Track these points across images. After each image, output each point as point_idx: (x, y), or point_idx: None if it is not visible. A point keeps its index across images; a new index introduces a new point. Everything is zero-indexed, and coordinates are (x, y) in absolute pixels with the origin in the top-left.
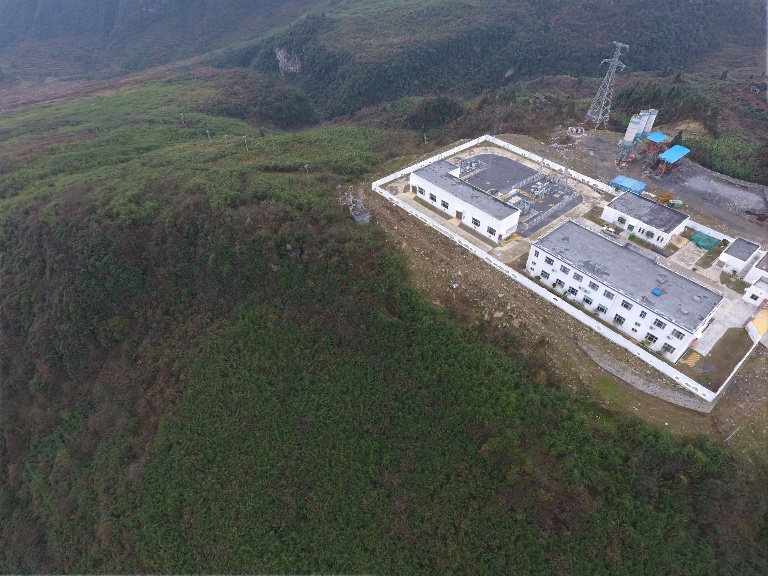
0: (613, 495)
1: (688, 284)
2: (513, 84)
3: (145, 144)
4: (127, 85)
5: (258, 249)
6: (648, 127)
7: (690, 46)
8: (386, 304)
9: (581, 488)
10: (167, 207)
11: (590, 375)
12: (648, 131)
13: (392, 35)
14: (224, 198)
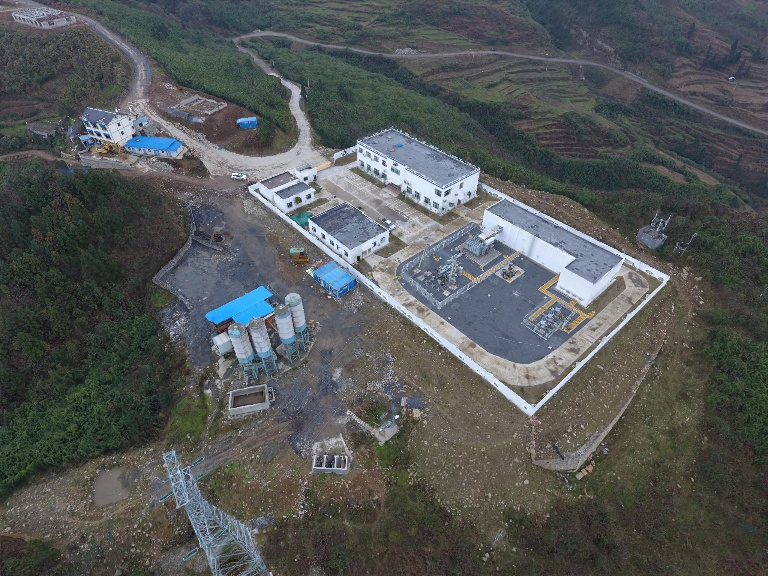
0: None
1: None
2: None
3: None
4: None
5: None
6: None
7: None
8: None
9: None
10: None
11: None
12: None
13: None
14: None
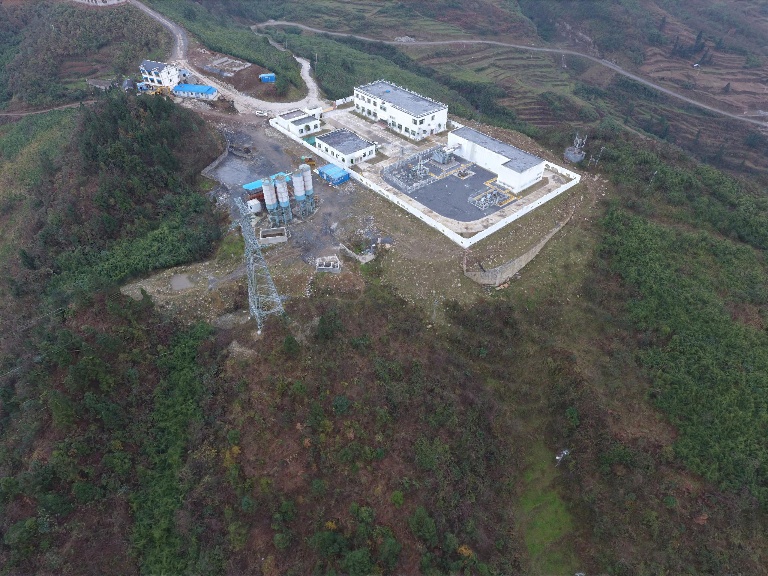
0: None
1: None
2: None
3: None
4: None
5: None
6: None
7: None
8: None
9: None
10: (762, 188)
11: None
12: None
13: None
14: None
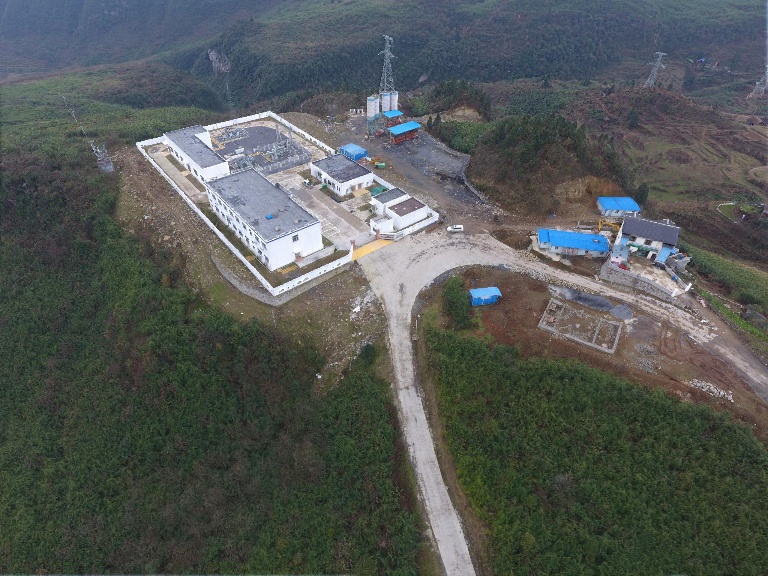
0: (180, 363)
1: (301, 212)
2: None
3: (12, 119)
4: None
5: (2, 187)
6: (393, 106)
7: (589, 58)
8: (88, 230)
9: (147, 354)
10: None
11: (211, 281)
12: None
13: (310, 39)
14: (4, 151)
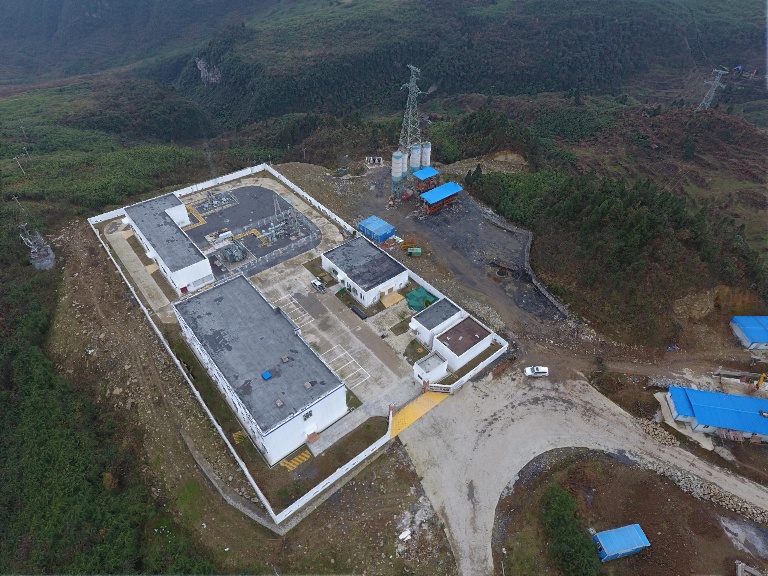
0: None
1: (315, 364)
2: (432, 101)
3: None
4: (22, 93)
5: None
6: (424, 161)
7: (615, 67)
8: (7, 372)
9: None
10: None
11: (179, 476)
12: (426, 165)
13: (307, 48)
14: None
